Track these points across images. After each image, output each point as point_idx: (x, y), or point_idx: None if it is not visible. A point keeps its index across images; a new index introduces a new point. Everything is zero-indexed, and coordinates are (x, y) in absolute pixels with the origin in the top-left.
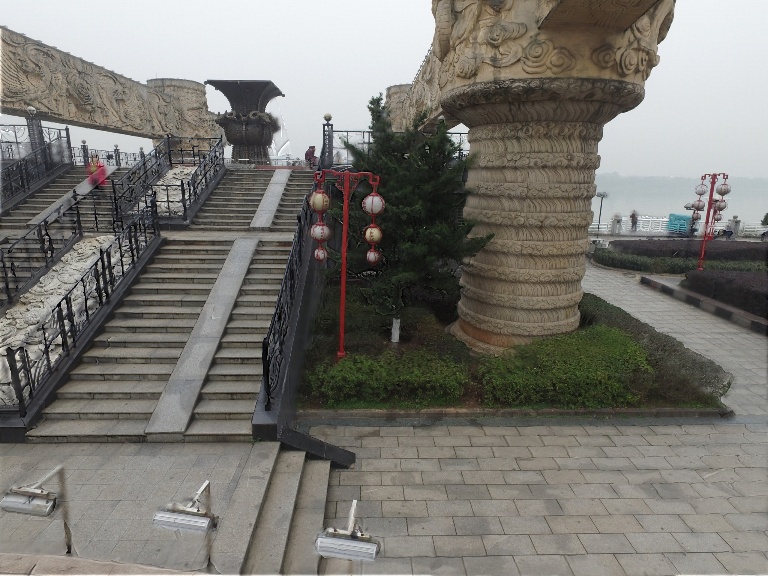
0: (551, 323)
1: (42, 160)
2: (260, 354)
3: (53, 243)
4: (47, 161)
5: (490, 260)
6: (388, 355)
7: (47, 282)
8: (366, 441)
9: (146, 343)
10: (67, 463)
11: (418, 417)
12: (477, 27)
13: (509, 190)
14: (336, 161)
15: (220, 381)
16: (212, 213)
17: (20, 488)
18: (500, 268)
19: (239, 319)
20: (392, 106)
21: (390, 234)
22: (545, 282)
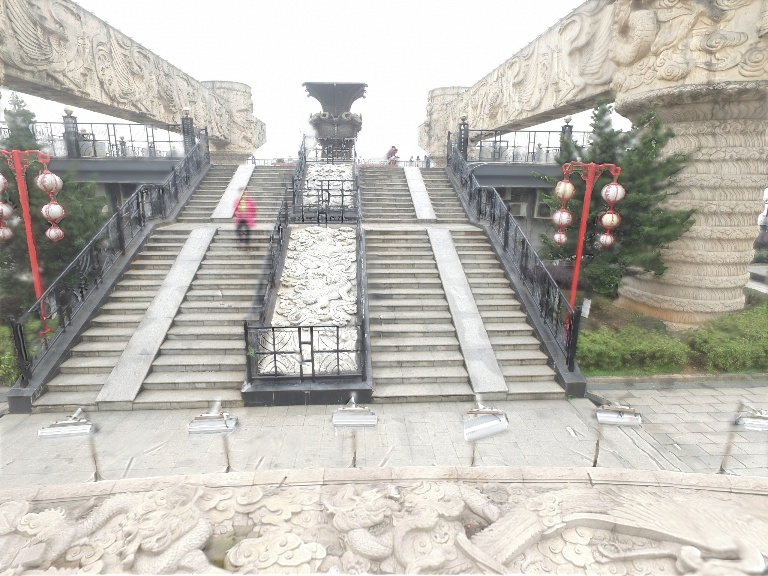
0: (730, 300)
1: (195, 158)
2: (522, 327)
3: (259, 234)
4: (198, 159)
5: (674, 245)
6: (606, 329)
7: (293, 268)
8: (630, 401)
9: (414, 319)
10: (430, 417)
11: (652, 382)
12: (690, 35)
13: (702, 181)
14: (469, 158)
15: (500, 350)
16: (371, 207)
17: (610, 406)
18: (687, 251)
19: (477, 298)
20: (435, 108)
21: (623, 219)
22: (729, 263)
